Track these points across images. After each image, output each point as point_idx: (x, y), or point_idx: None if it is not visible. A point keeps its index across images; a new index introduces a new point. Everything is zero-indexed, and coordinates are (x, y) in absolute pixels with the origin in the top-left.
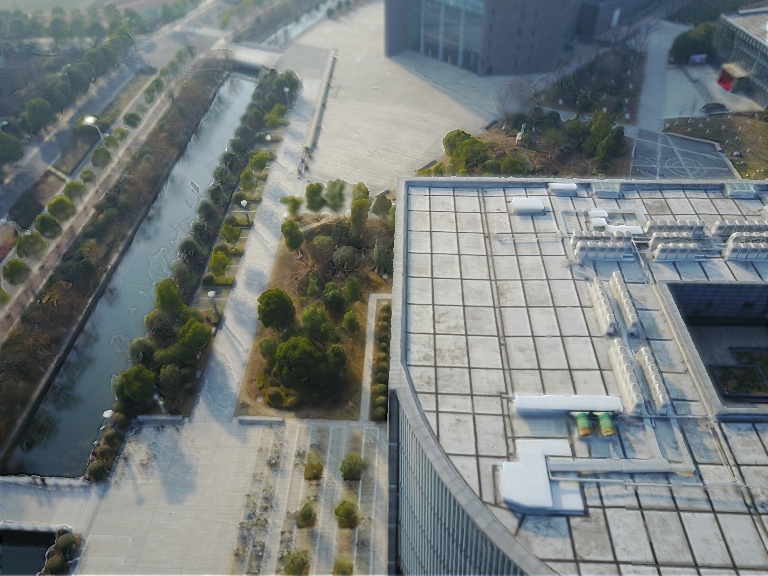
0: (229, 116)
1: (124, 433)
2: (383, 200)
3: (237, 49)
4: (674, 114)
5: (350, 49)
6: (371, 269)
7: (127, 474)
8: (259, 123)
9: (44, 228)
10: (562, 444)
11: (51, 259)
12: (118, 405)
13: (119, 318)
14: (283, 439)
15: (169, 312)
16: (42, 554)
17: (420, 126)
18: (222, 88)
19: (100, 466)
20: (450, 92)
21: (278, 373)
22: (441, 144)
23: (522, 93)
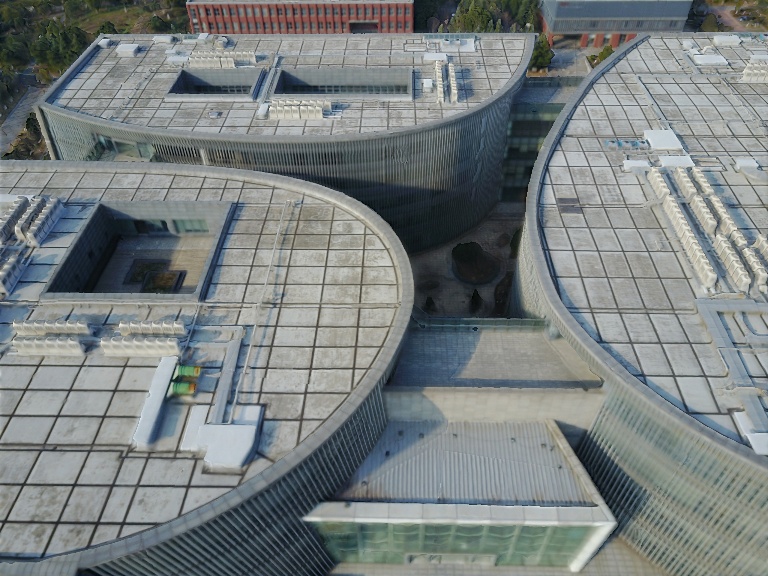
0: None
1: None
2: None
3: None
4: None
5: None
6: None
7: None
8: None
9: None
10: (196, 411)
11: None
12: None
13: None
14: None
15: None
16: None
17: None
18: None
19: None
20: None
21: None
22: None
23: None
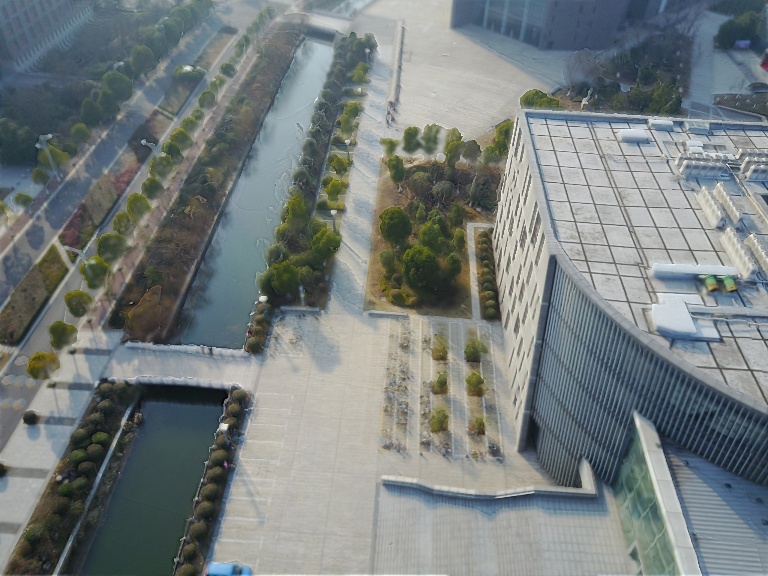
0: (306, 75)
1: (270, 319)
2: (474, 145)
3: (309, 15)
4: (722, 90)
5: (416, 20)
6: (465, 203)
7: (279, 350)
8: (343, 79)
9: (170, 154)
10: (695, 297)
11: (175, 183)
12: None
13: (235, 238)
14: (409, 330)
15: (297, 225)
16: (209, 411)
17: (491, 89)
18: (298, 49)
19: (257, 341)
20: (515, 62)
21: (405, 274)
22: (512, 105)
23: (588, 62)
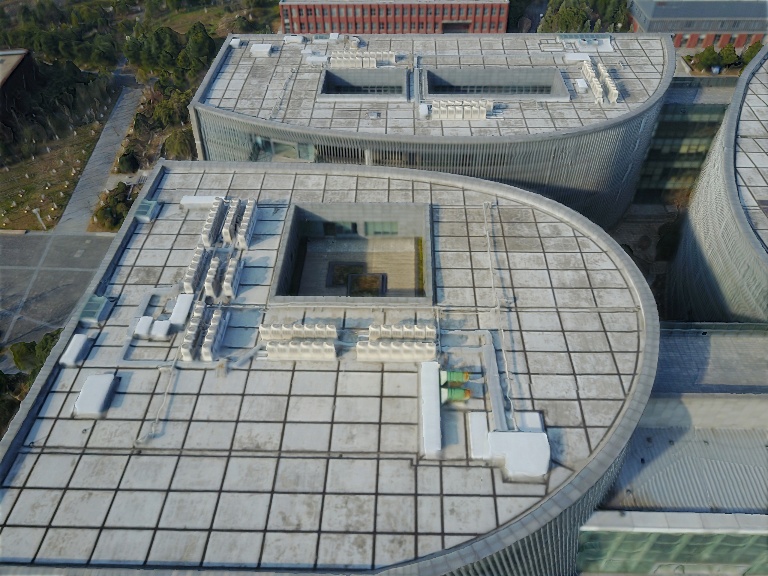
0: None
1: None
2: None
3: None
4: None
5: None
6: None
7: None
8: None
9: None
10: (474, 418)
11: None
12: None
13: None
14: None
15: None
16: None
17: None
18: None
19: None
20: None
21: None
22: None
23: None
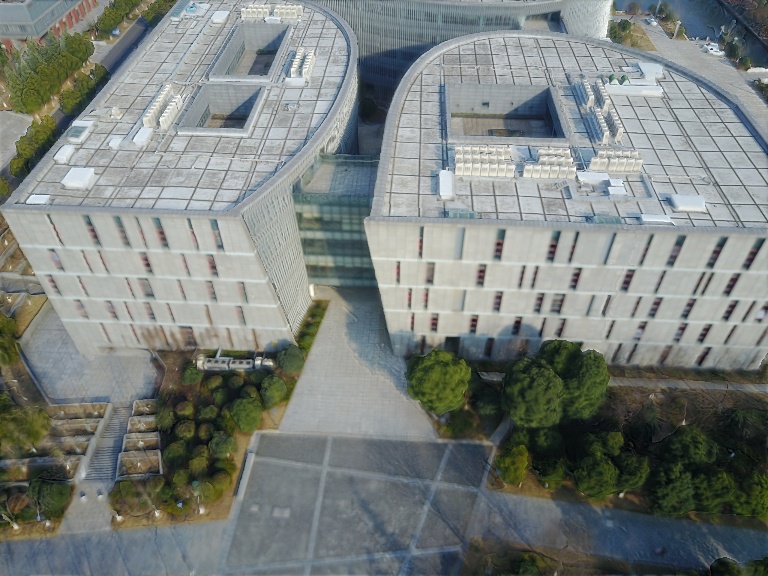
0: None
1: None
2: None
3: None
4: None
5: None
6: None
7: None
8: None
9: None
10: None
11: None
12: None
13: None
14: None
15: None
16: None
17: None
18: None
19: None
20: None
21: None
22: None
23: None
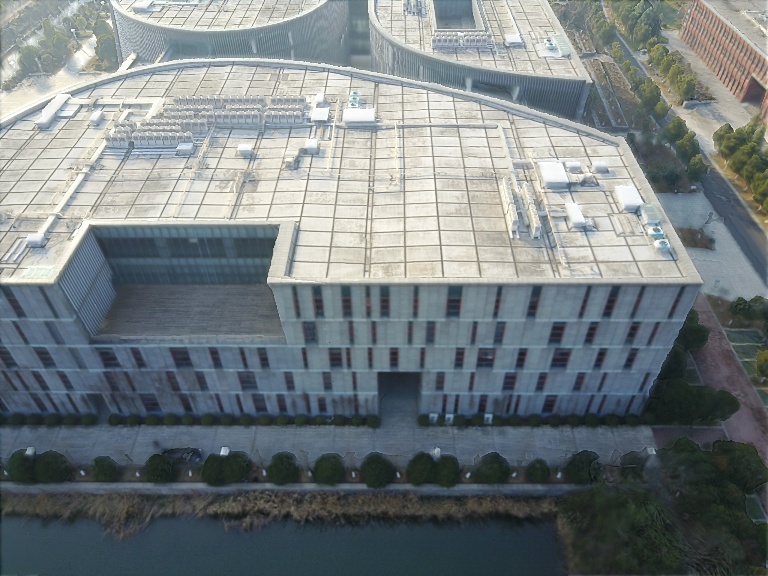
0: None
1: (21, 79)
2: None
3: None
4: None
5: None
6: None
7: (21, 89)
8: None
9: None
10: None
11: None
12: (19, 69)
13: None
14: None
15: (50, 38)
16: None
17: None
18: None
19: (8, 84)
20: None
21: (97, 50)
22: None
23: None
